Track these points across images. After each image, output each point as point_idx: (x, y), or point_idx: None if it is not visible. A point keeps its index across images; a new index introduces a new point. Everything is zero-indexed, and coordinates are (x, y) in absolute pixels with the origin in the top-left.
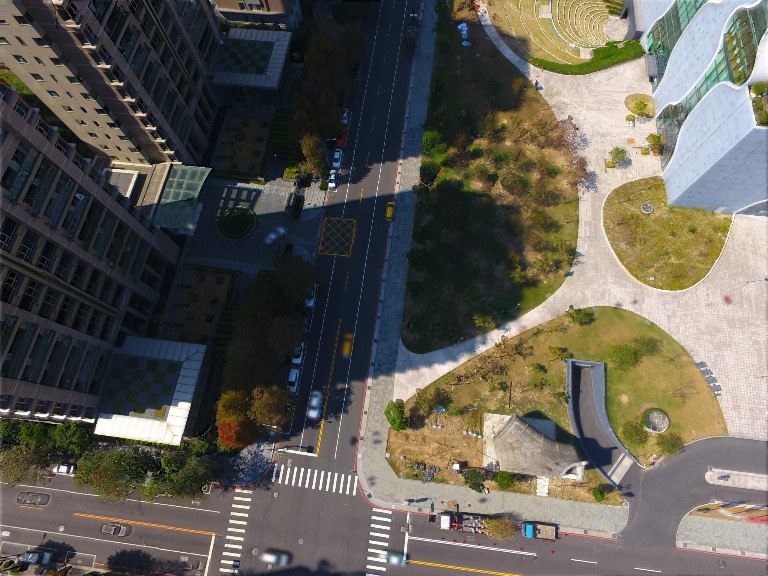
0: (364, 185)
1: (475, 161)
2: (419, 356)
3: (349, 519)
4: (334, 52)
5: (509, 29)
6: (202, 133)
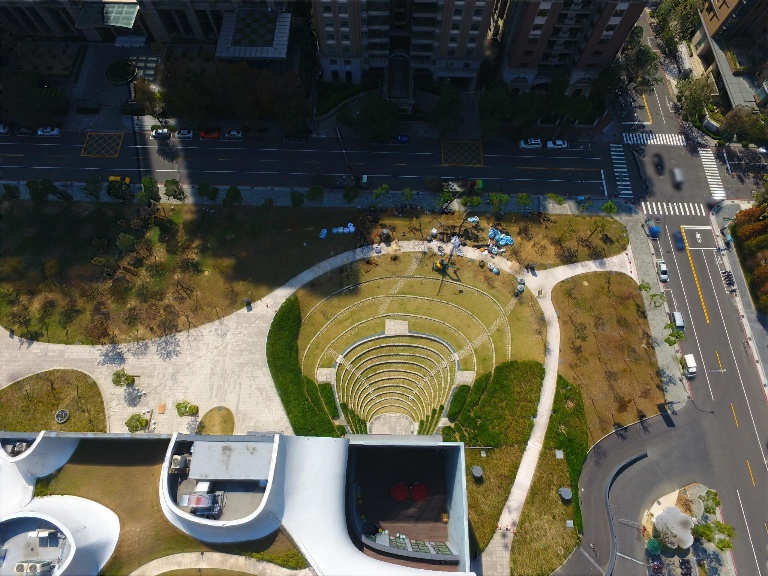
0: (154, 159)
1: (163, 248)
2: None
3: None
4: (233, 83)
5: (356, 281)
6: (199, 27)
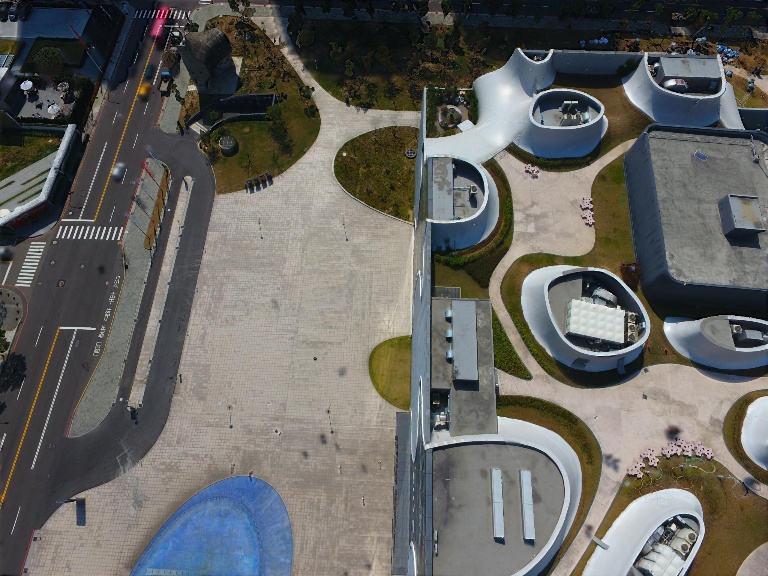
0: None
1: (452, 52)
2: (286, 28)
3: (186, 1)
4: None
5: None
6: None
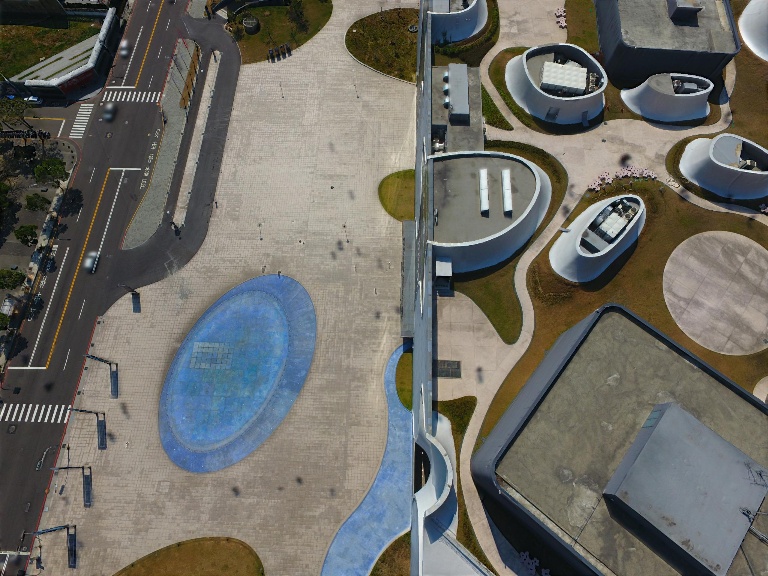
0: None
1: None
2: None
3: None
4: None
5: None
6: None
